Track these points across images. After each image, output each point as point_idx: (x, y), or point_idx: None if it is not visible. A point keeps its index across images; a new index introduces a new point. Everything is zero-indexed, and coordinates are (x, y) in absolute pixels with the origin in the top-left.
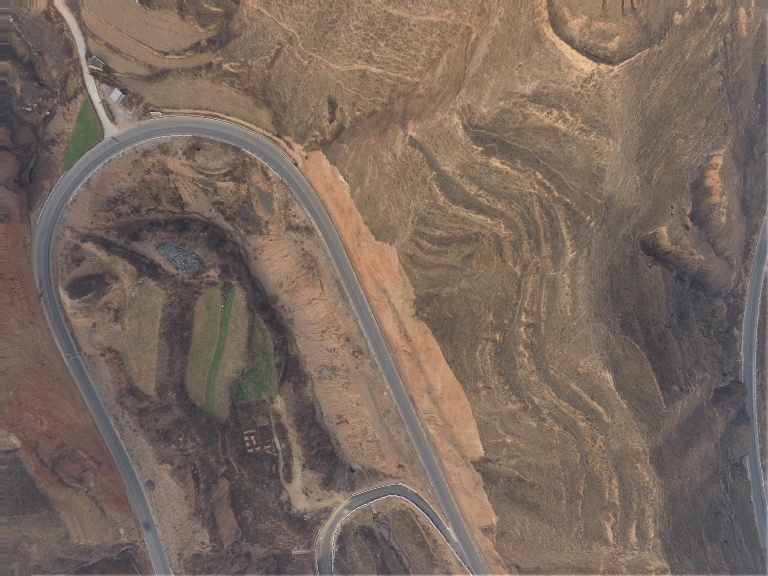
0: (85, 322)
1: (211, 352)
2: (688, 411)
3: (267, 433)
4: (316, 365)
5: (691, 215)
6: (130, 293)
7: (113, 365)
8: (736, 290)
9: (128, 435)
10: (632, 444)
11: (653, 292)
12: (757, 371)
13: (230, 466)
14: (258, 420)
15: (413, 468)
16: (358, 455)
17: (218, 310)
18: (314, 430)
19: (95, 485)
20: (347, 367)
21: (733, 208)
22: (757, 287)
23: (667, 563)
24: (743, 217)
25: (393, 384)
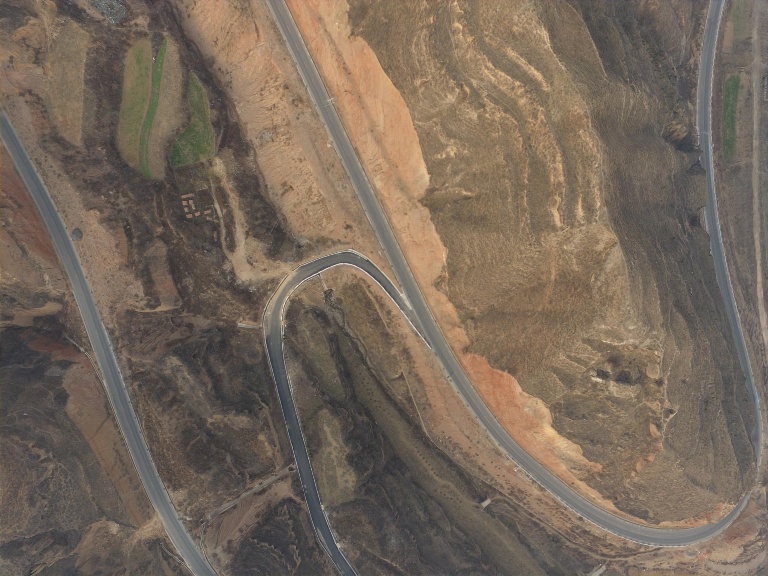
0: (0, 53)
1: (143, 109)
2: (636, 121)
3: (207, 198)
4: (257, 131)
5: None
6: (51, 33)
7: (35, 109)
8: (688, 64)
9: (52, 180)
10: (573, 109)
11: None
12: (713, 146)
13: (167, 229)
14: (197, 184)
15: (361, 228)
16: (305, 226)
17: (149, 63)
18: (258, 202)
19: (15, 223)
20: (288, 120)
21: None
22: (709, 61)
23: (615, 234)
24: None
25: (336, 135)
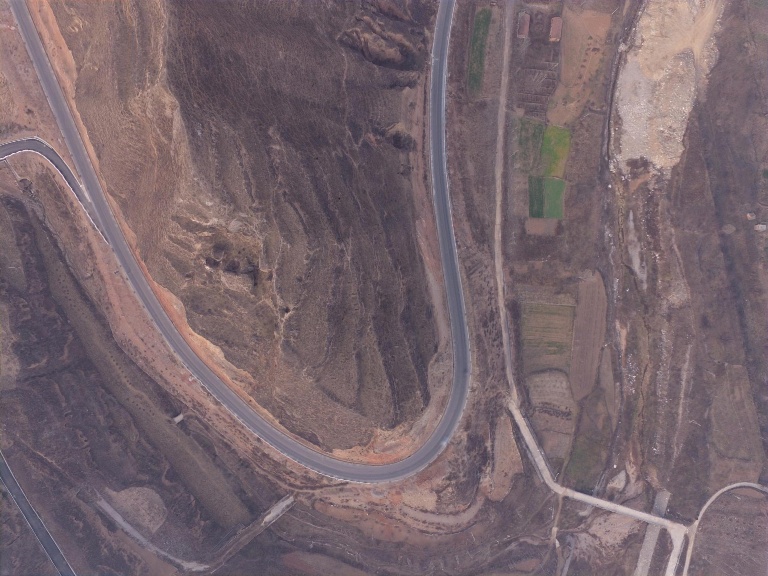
0: None
1: None
2: (276, 10)
3: None
4: None
5: None
6: None
7: None
8: None
9: None
10: None
11: None
12: (449, 76)
13: None
14: None
15: (42, 113)
16: (2, 113)
17: None
18: None
19: None
20: None
21: None
22: None
23: (175, 97)
24: None
25: (21, 19)
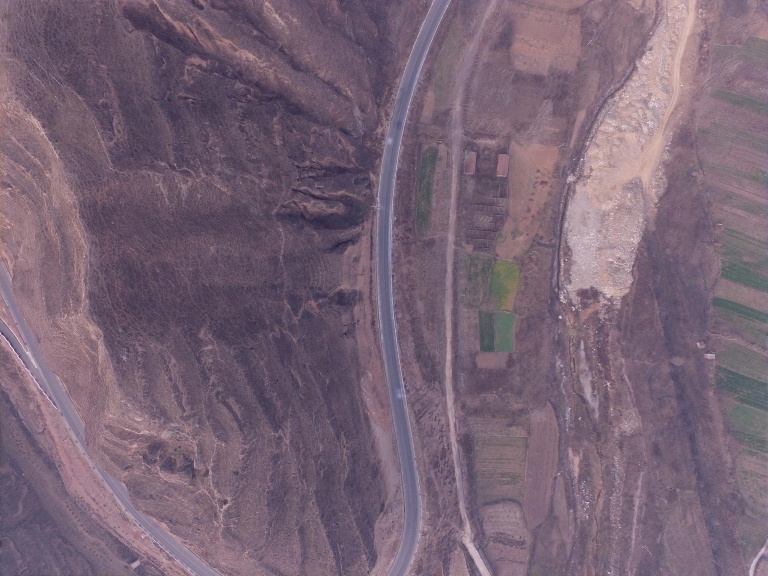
0: None
1: None
2: (206, 203)
3: None
4: None
5: (229, 6)
6: None
7: None
8: (375, 134)
9: None
10: (65, 198)
11: (135, 59)
12: (396, 219)
13: None
14: None
15: None
16: None
17: None
18: None
19: None
20: None
21: (282, 4)
22: (398, 132)
23: (99, 327)
24: (332, 34)
25: None
